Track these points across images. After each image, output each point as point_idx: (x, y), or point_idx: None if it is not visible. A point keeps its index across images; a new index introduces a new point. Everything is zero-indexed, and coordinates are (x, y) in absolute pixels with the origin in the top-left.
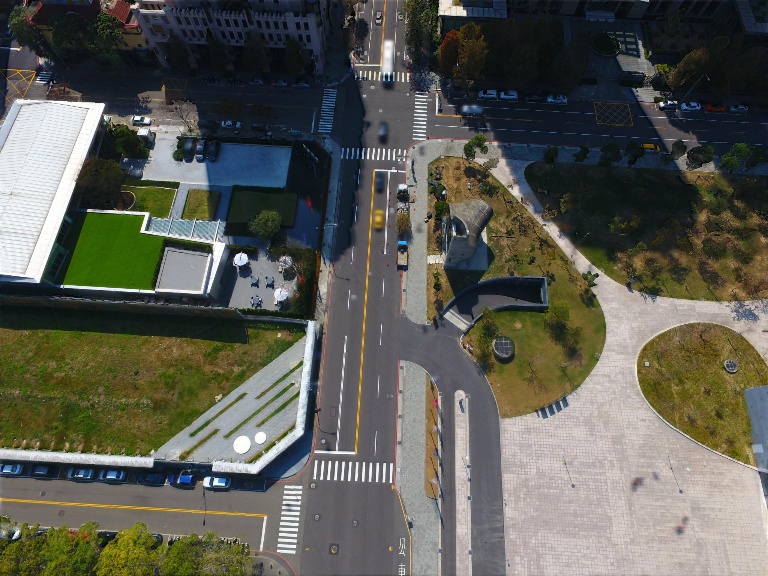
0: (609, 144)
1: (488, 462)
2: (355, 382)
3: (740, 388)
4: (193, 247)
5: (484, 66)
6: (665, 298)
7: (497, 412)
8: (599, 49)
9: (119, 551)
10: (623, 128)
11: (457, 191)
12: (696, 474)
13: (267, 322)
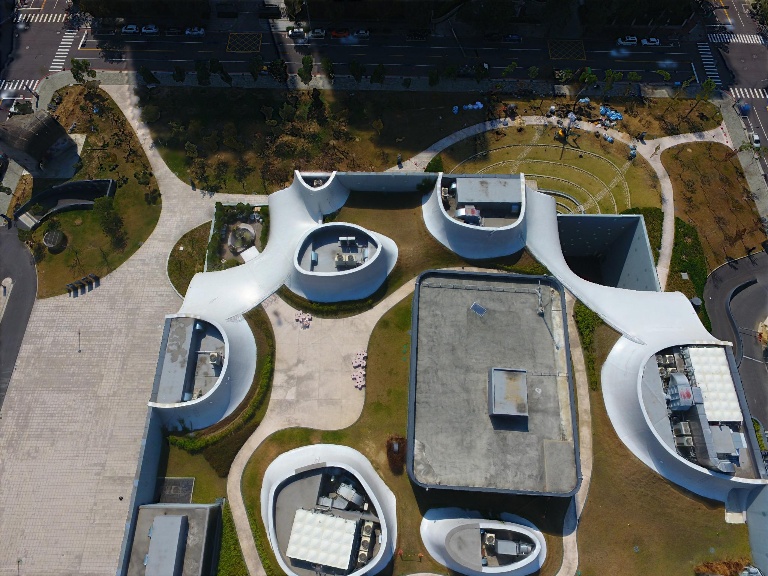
0: (196, 62)
1: (12, 335)
2: None
3: None
4: None
5: (114, 1)
6: (221, 194)
7: (35, 294)
8: None
9: None
10: (249, 54)
11: (71, 113)
12: None
13: None
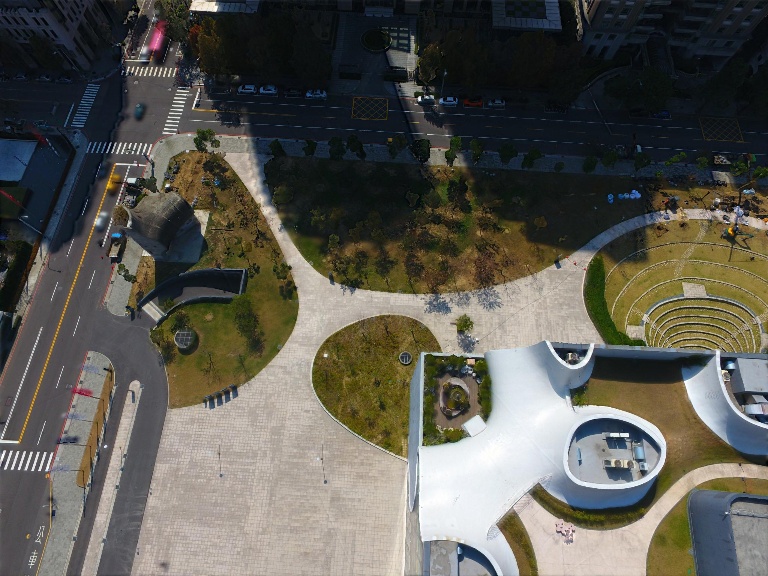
0: None
1: (145, 452)
2: (38, 372)
3: (410, 380)
4: None
5: (235, 61)
6: (364, 290)
7: (167, 402)
8: (368, 44)
9: None
10: (376, 122)
11: (190, 185)
12: (345, 465)
13: None
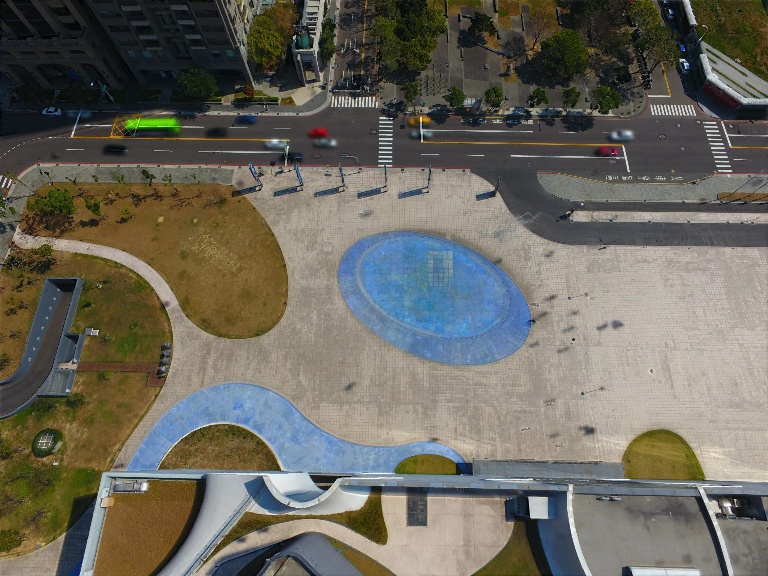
0: None
1: (762, 237)
2: None
3: None
4: None
5: None
6: None
7: None
8: None
9: None
10: None
11: None
12: None
13: None
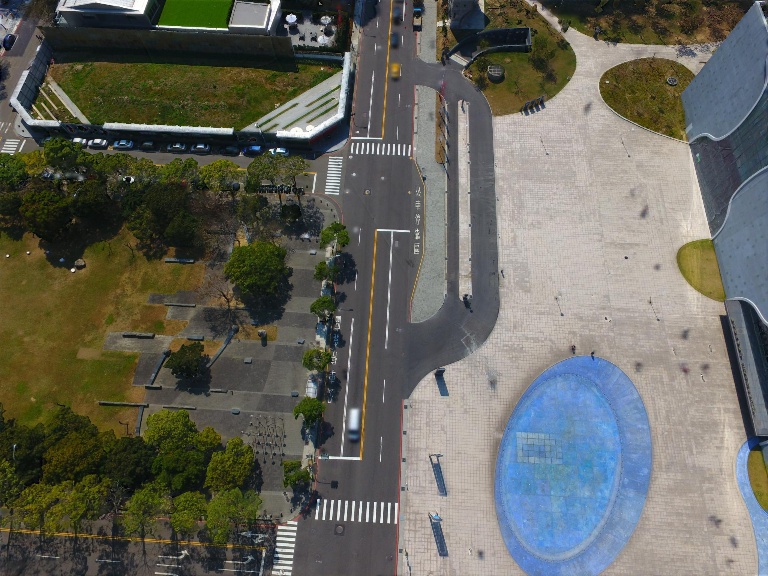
0: None
1: (483, 142)
2: (381, 98)
3: (679, 95)
4: (256, 1)
5: None
6: (624, 44)
7: (490, 113)
8: None
9: (215, 162)
10: None
11: None
12: (641, 146)
13: (313, 59)
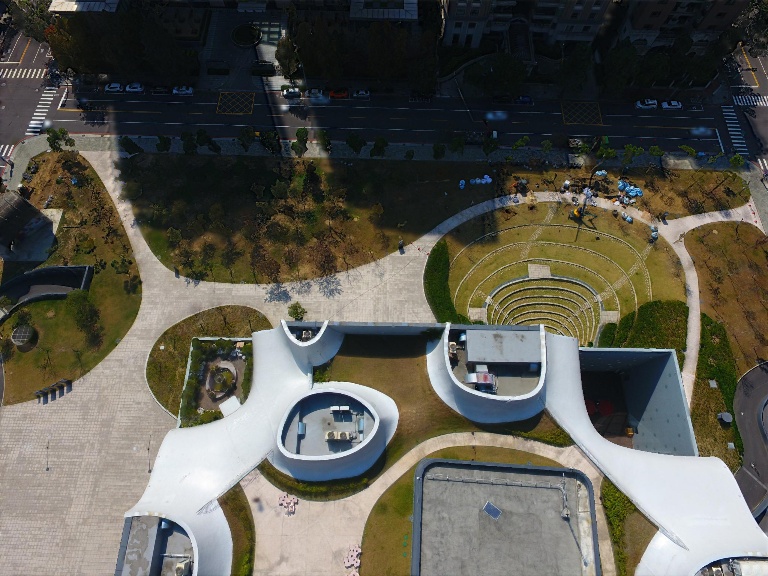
0: None
1: None
2: None
3: None
4: None
5: (96, 60)
6: (207, 282)
7: (1, 400)
8: (238, 40)
9: None
10: (241, 117)
11: (47, 184)
12: None
13: None
